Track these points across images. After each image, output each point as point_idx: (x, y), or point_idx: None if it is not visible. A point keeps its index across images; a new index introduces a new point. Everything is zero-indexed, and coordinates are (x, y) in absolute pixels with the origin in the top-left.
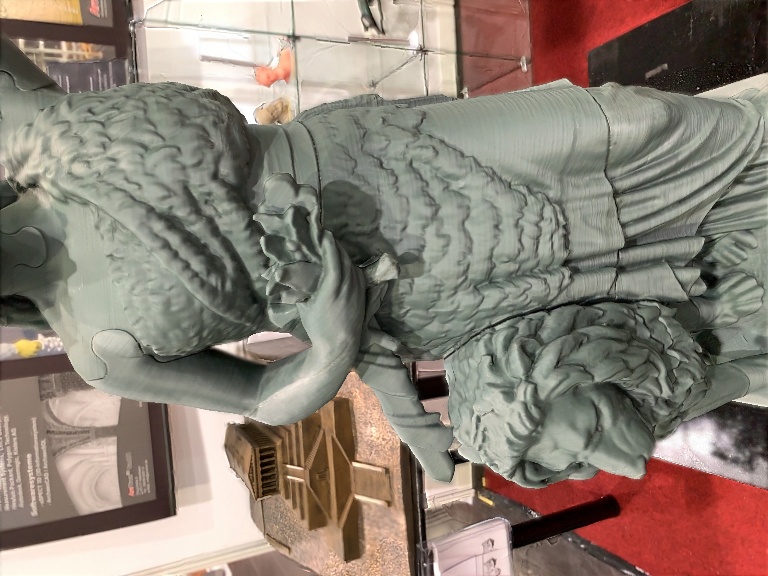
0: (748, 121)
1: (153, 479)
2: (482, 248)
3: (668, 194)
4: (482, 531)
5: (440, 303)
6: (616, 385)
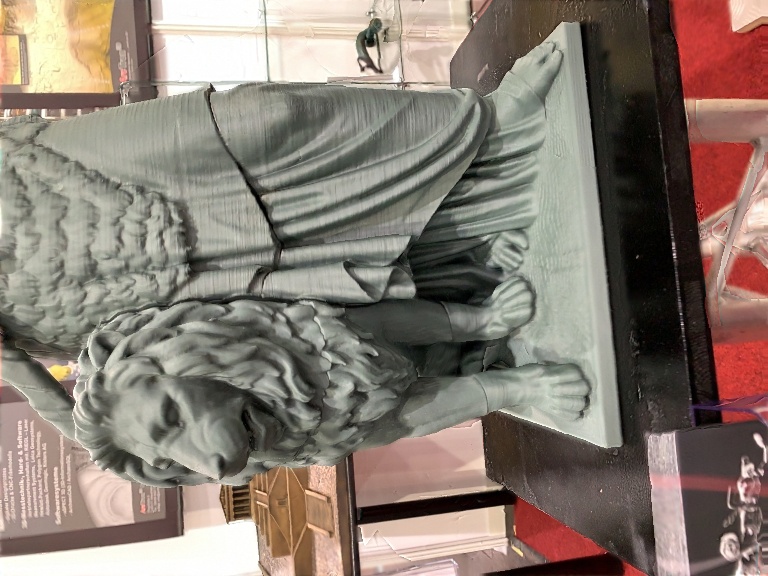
0: (458, 110)
1: (164, 499)
2: (75, 245)
3: (335, 190)
4: (426, 573)
5: (42, 298)
6: (224, 383)
